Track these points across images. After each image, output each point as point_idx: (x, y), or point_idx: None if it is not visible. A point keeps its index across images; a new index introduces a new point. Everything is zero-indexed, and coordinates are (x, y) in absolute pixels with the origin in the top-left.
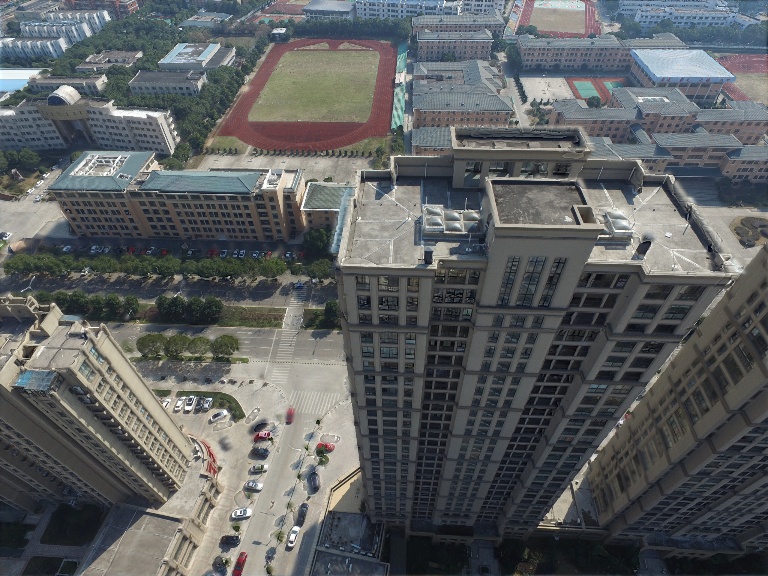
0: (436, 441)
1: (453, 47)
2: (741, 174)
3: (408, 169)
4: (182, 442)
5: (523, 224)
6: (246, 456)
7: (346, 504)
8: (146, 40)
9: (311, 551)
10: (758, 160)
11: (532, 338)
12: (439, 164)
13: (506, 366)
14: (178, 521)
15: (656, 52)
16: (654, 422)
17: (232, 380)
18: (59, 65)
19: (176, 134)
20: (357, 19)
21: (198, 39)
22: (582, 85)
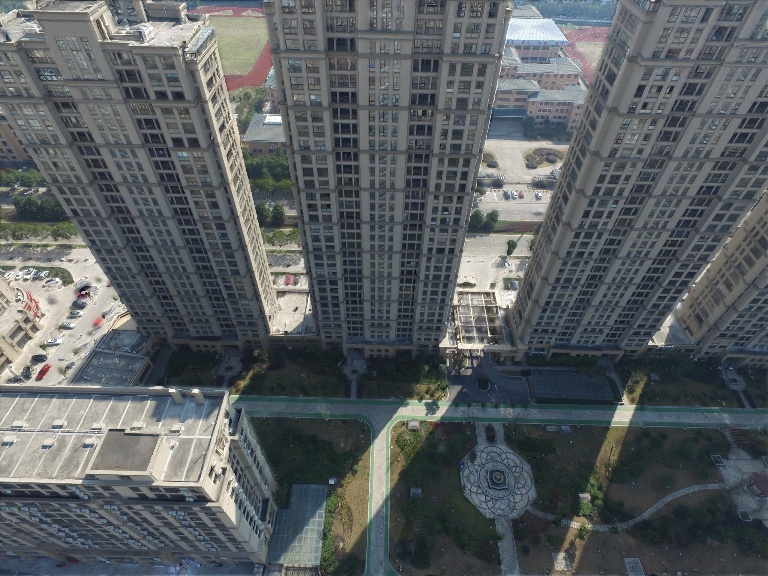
0: (131, 228)
1: None
2: (542, 114)
3: None
4: (2, 285)
5: (46, 10)
6: (67, 307)
7: (128, 325)
8: None
9: (90, 351)
10: (552, 101)
11: (117, 110)
12: None
13: (119, 139)
14: None
15: (511, 20)
16: None
17: (70, 259)
18: None
19: None
20: None
21: None
22: None
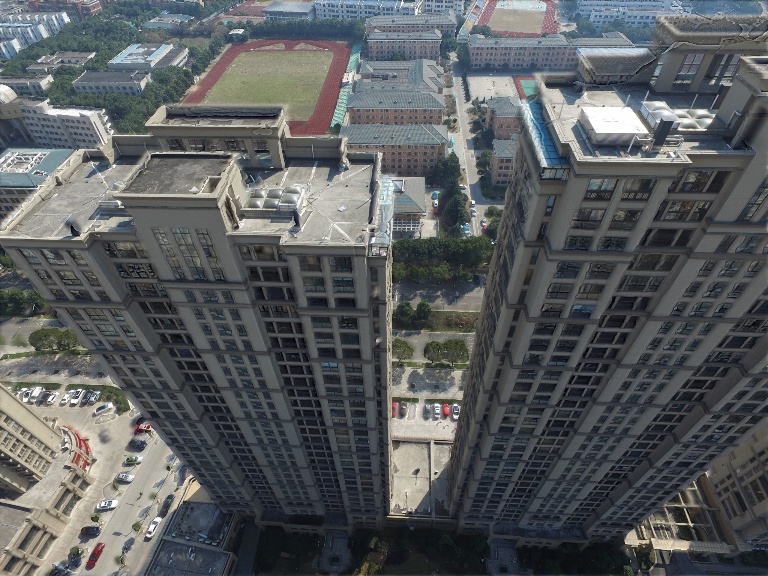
0: (229, 425)
1: (403, 47)
2: None
3: (130, 148)
4: (46, 433)
5: (142, 194)
6: (123, 448)
7: (202, 494)
8: (104, 41)
9: (157, 540)
10: None
11: (237, 314)
12: (158, 143)
13: (234, 344)
14: (29, 511)
15: (601, 51)
16: (465, 407)
17: None
18: (11, 66)
19: (116, 133)
20: (314, 20)
21: (153, 40)
22: (528, 84)
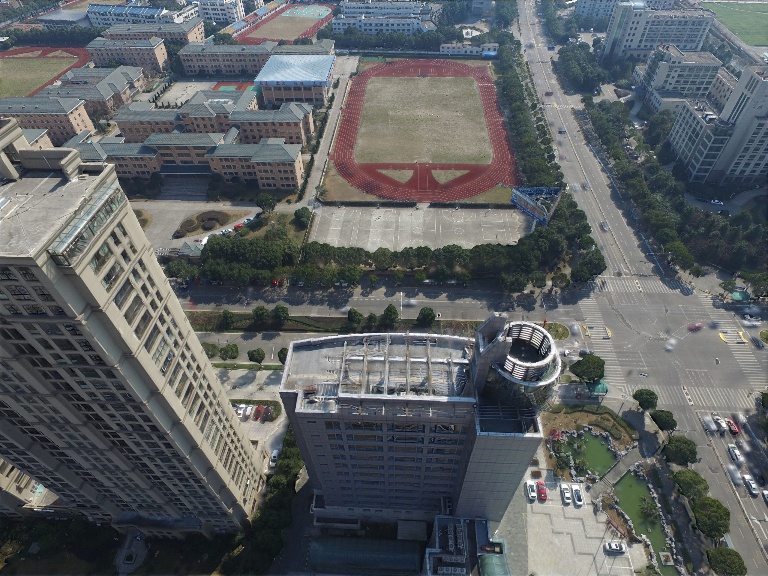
0: None
1: (121, 54)
2: (229, 171)
3: None
4: None
5: None
6: None
7: None
8: None
9: None
10: (230, 157)
11: None
12: None
13: None
14: None
15: (288, 57)
16: None
17: None
18: None
19: None
20: (73, 28)
21: None
22: (225, 89)
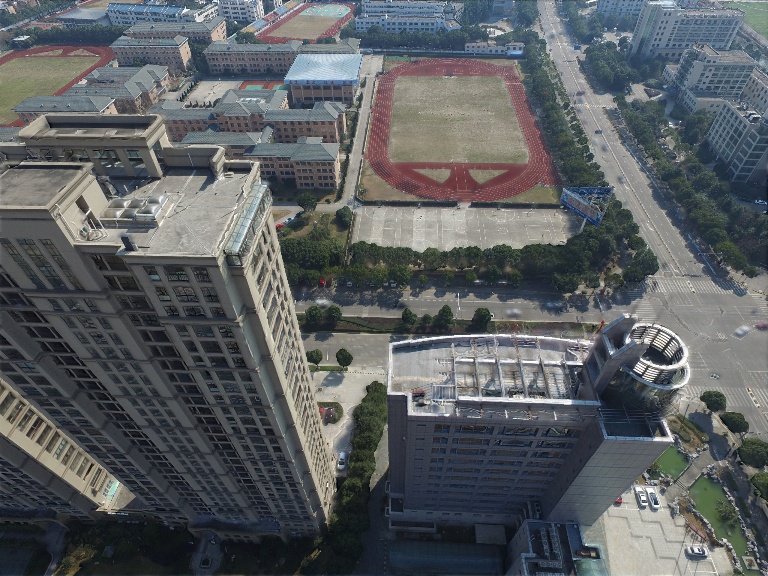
0: None
1: (146, 53)
2: (267, 170)
3: None
4: None
5: None
6: None
7: None
8: None
9: None
10: (269, 157)
11: None
12: None
13: None
14: None
15: (315, 56)
16: None
17: None
18: None
19: None
20: (94, 27)
21: None
22: (251, 88)
